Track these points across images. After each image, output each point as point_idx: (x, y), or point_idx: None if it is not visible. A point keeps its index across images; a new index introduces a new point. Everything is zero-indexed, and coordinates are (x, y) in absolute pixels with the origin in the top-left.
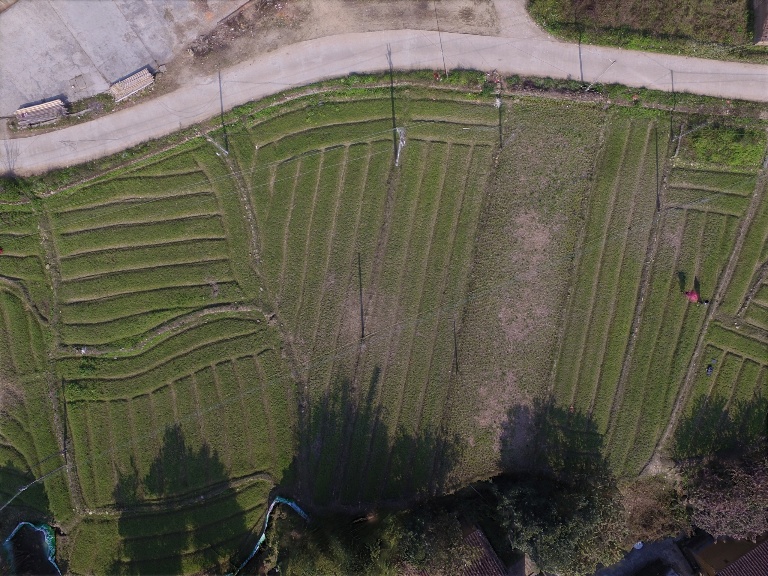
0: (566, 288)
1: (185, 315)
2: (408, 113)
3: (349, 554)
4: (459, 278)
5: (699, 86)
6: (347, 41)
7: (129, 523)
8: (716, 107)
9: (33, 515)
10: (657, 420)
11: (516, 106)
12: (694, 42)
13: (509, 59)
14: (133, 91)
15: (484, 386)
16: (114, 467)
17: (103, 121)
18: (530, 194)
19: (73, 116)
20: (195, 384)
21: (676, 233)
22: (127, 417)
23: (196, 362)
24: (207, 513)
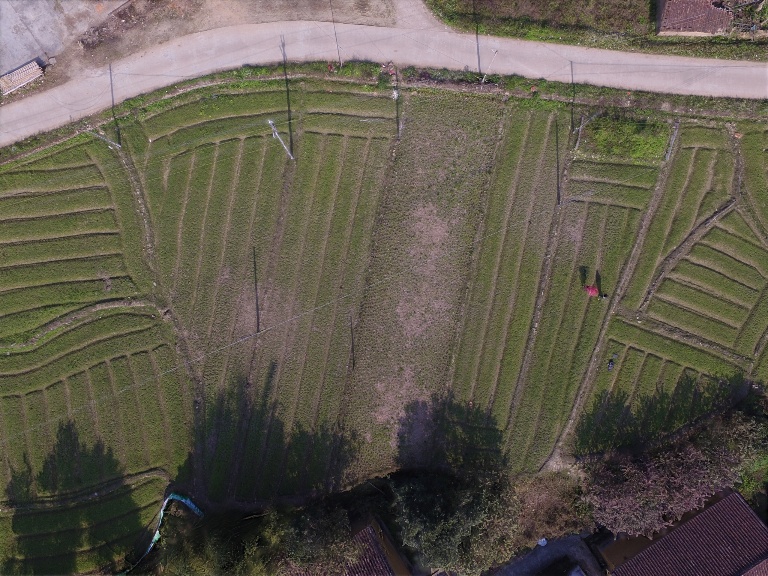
0: (465, 282)
1: (77, 310)
2: (304, 105)
3: (220, 551)
4: (356, 272)
5: (599, 77)
6: (240, 32)
7: (23, 520)
8: (616, 98)
9: None
10: (557, 416)
11: (414, 98)
12: (593, 32)
13: (405, 50)
14: (21, 84)
15: (381, 381)
16: (7, 464)
17: None
18: (428, 187)
19: None
20: (89, 380)
21: (577, 226)
22: (20, 413)
23: (90, 358)
24: (102, 510)
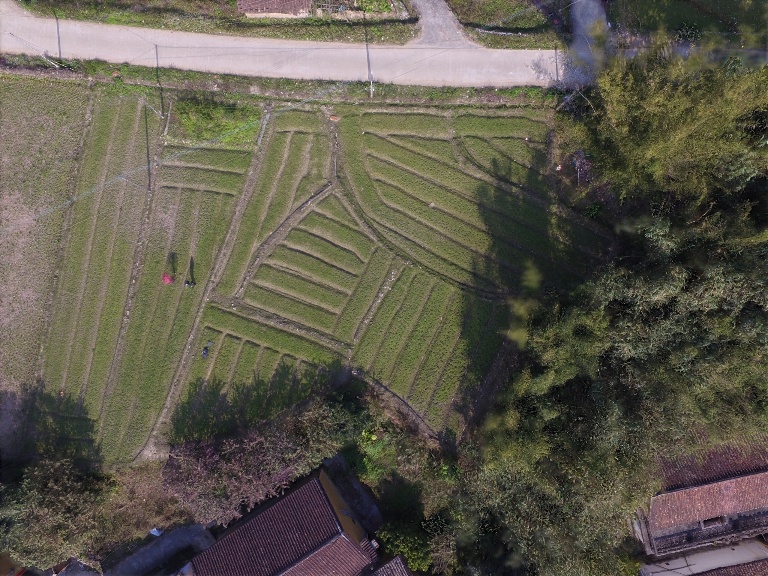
0: (53, 271)
1: None
2: None
3: None
4: None
5: (185, 61)
6: None
7: None
8: (202, 82)
9: None
10: (150, 404)
11: None
12: (175, 15)
13: None
14: None
15: None
16: None
17: None
18: (14, 175)
19: None
20: None
21: (169, 213)
22: None
23: None
24: None
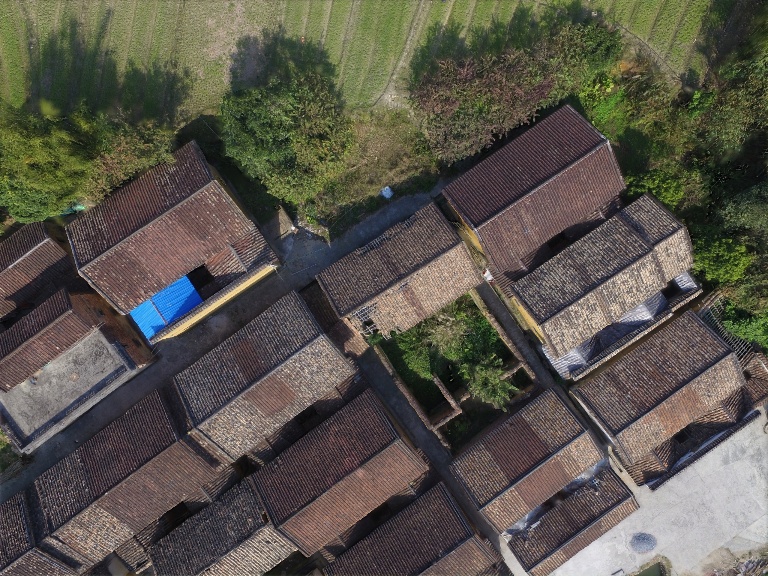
0: None
1: None
2: None
3: None
4: None
5: None
6: None
7: None
8: None
9: None
10: (390, 48)
11: None
12: None
13: None
14: None
15: (212, 18)
16: None
17: None
18: None
19: None
20: None
21: None
22: None
23: None
24: None
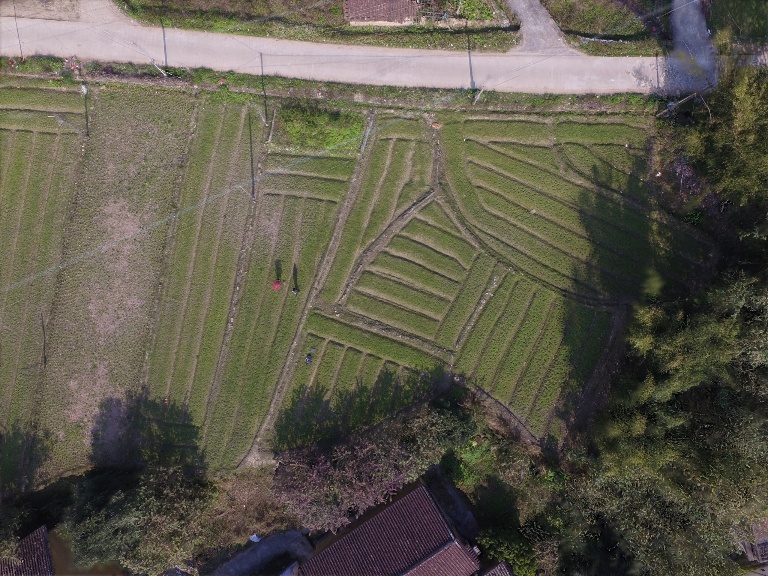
0: (158, 278)
1: None
2: None
3: None
4: (46, 269)
5: (290, 69)
6: None
7: None
8: (307, 90)
9: None
10: (254, 411)
11: (103, 93)
12: (280, 24)
13: (89, 44)
14: None
15: (74, 379)
16: None
17: None
18: (119, 182)
19: None
20: None
21: (272, 220)
22: None
23: None
24: None
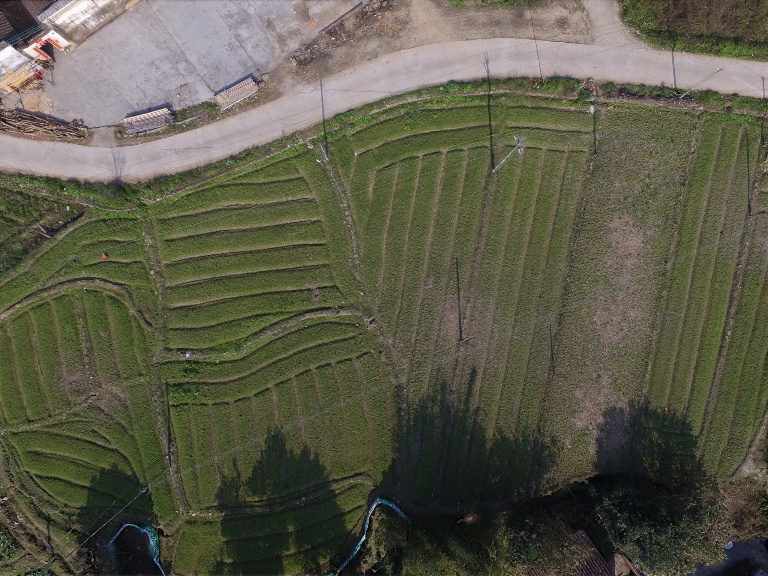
0: (660, 292)
1: (287, 319)
2: (504, 120)
3: (470, 554)
4: (555, 282)
5: None
6: (446, 50)
7: (231, 524)
8: None
9: (137, 517)
10: (750, 421)
11: (610, 113)
12: None
13: (604, 67)
14: (238, 100)
15: (580, 388)
16: (217, 469)
17: (208, 129)
18: (624, 199)
19: (178, 124)
20: (295, 387)
21: (767, 237)
22: (229, 420)
23: (297, 365)
24: (308, 514)
